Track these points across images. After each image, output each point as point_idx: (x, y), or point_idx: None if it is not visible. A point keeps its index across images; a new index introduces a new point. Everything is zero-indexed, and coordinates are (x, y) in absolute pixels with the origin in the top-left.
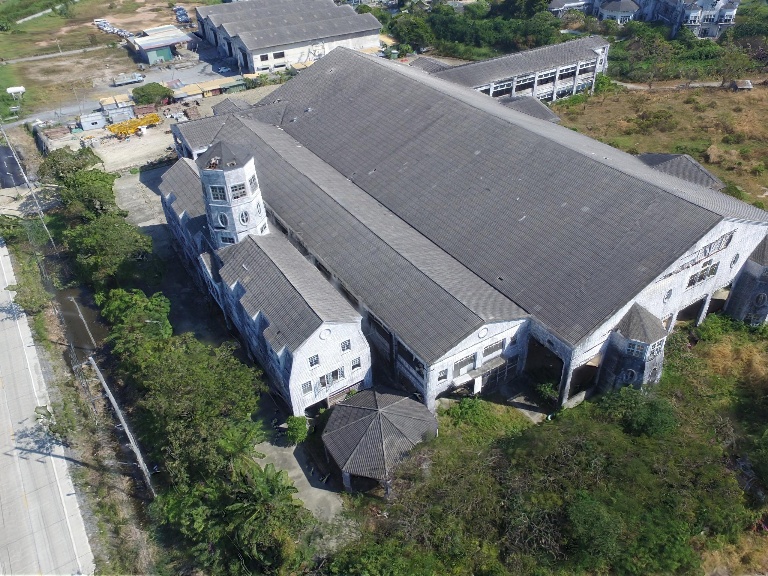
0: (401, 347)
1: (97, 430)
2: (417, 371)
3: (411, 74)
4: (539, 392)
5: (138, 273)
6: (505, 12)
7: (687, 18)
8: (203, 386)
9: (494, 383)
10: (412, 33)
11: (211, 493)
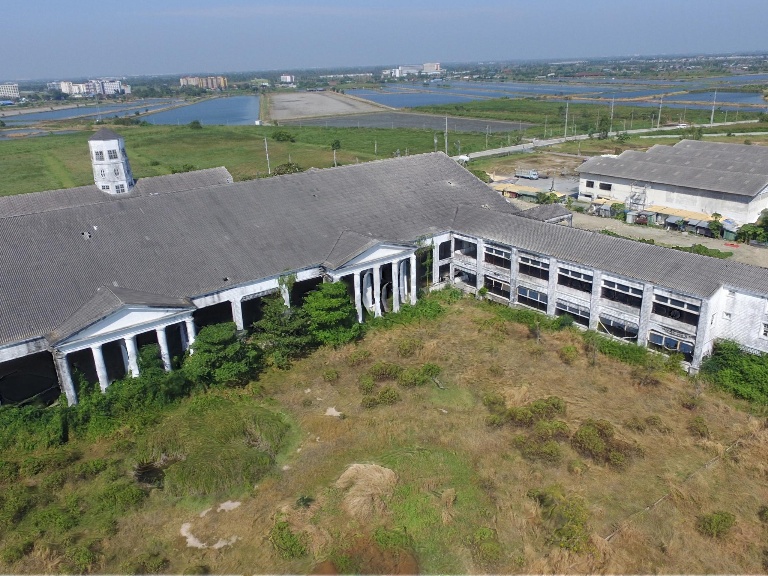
0: None
1: None
2: None
3: (370, 176)
4: None
5: None
6: None
7: None
8: None
9: None
10: None
11: None
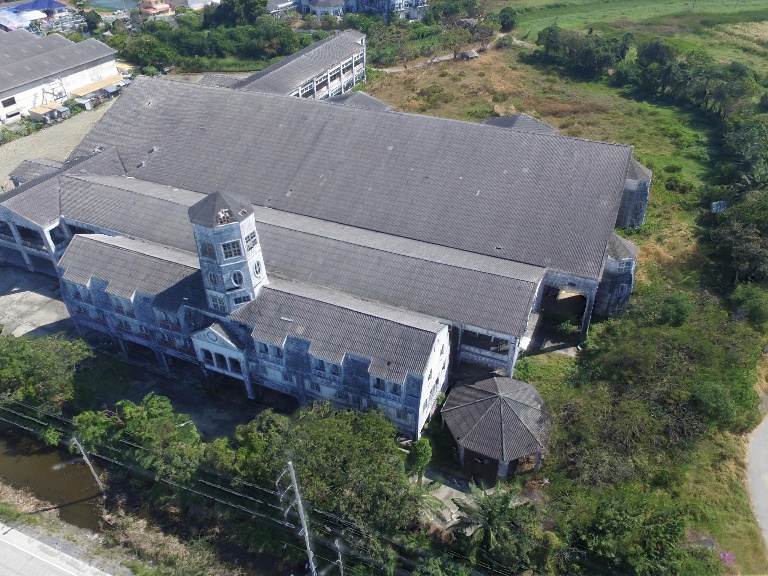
0: (470, 336)
1: (204, 570)
2: (493, 351)
3: None
4: (563, 331)
5: (95, 385)
6: (224, 20)
7: (394, 5)
8: (358, 447)
9: None
10: (152, 53)
11: (422, 545)
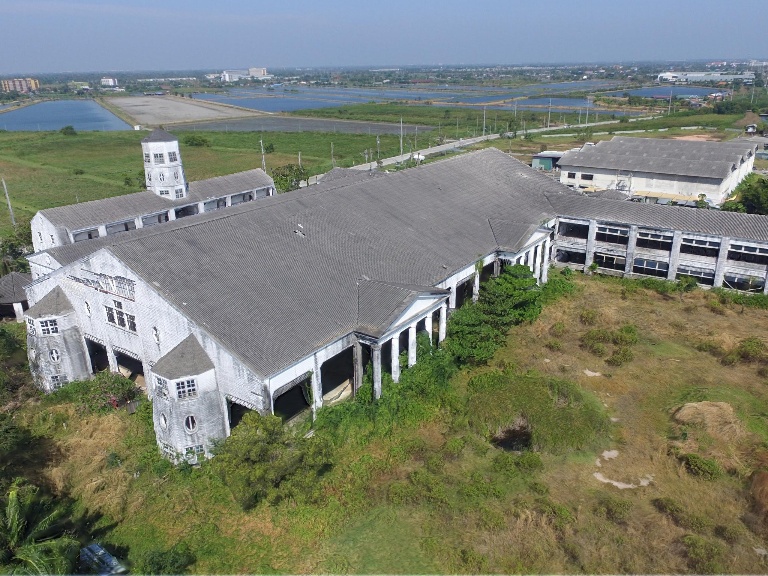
0: None
1: None
2: None
3: (464, 170)
4: None
5: None
6: None
7: None
8: None
9: None
10: (752, 191)
11: None
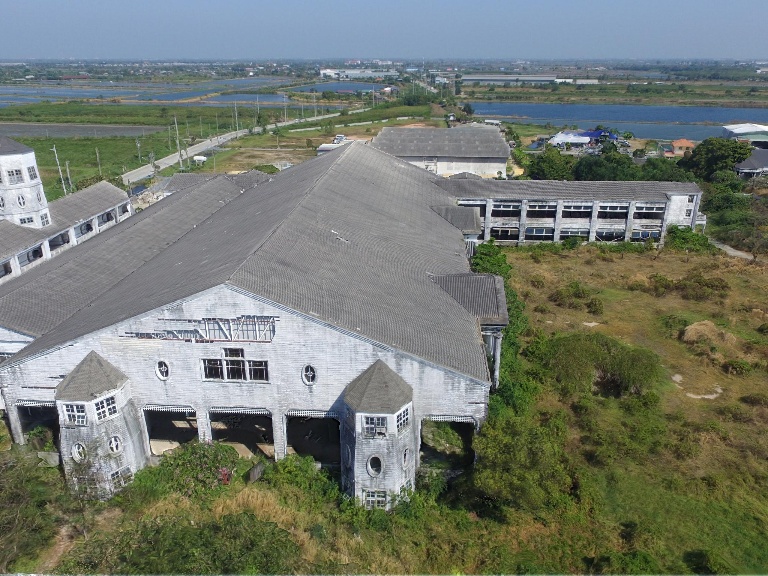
0: None
1: None
2: None
3: (366, 164)
4: None
5: None
6: (684, 167)
7: None
8: None
9: (23, 409)
10: (536, 166)
11: None
